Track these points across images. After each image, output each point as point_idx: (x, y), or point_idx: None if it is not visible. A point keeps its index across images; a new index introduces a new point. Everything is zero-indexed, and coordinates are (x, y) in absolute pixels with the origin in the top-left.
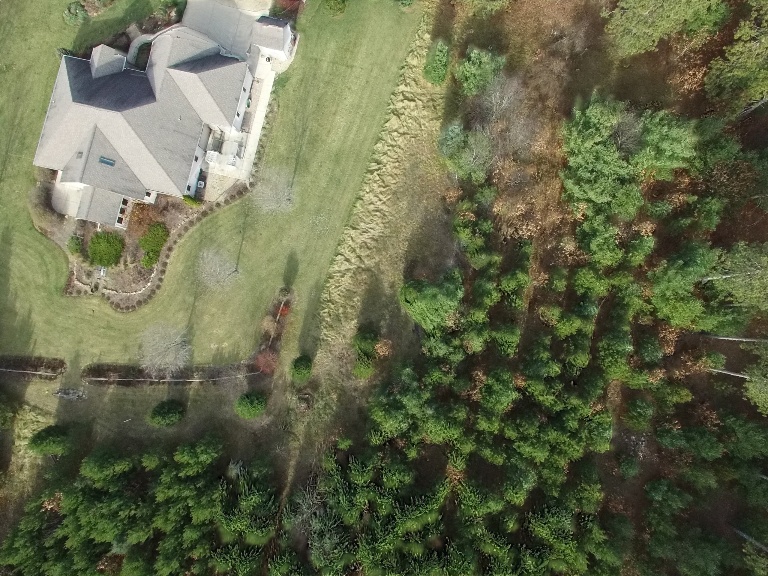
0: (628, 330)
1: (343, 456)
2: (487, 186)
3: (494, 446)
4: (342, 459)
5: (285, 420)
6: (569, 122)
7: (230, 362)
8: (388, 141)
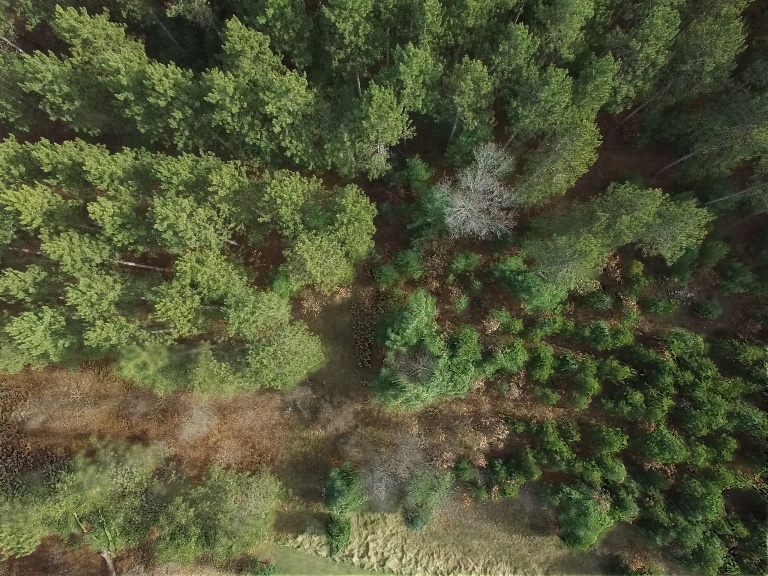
0: (588, 331)
1: None
2: (459, 472)
3: (718, 447)
4: None
5: None
6: (381, 391)
7: None
8: (412, 567)
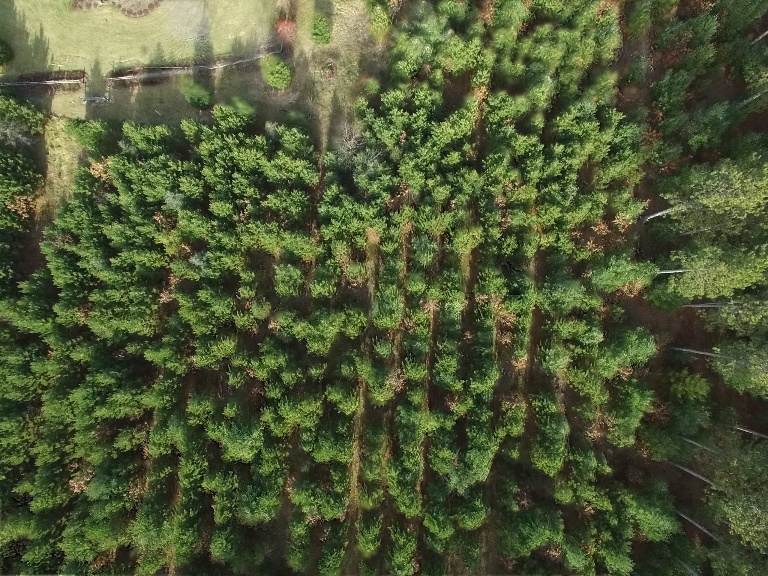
0: None
1: (374, 97)
2: None
3: (516, 60)
4: (374, 100)
5: (312, 93)
6: None
7: (250, 49)
8: None
